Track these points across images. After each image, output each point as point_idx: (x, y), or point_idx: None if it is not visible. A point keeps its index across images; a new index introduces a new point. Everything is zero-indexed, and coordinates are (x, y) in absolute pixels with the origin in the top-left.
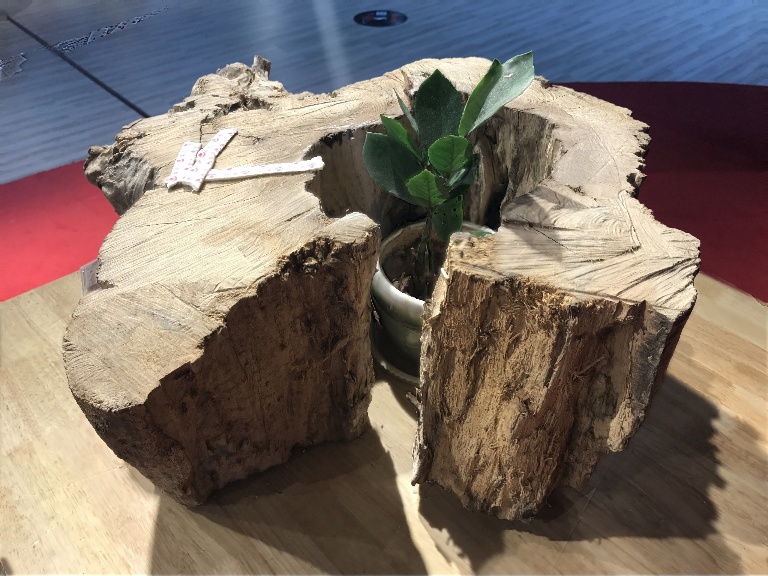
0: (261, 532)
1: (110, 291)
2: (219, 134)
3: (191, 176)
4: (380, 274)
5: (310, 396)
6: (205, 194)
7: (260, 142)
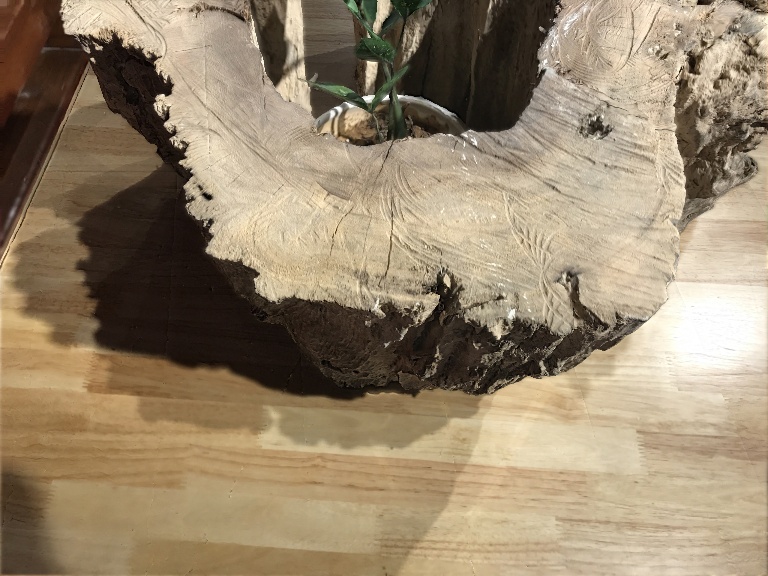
0: None
1: None
2: None
3: None
4: (425, 100)
5: None
6: None
7: None
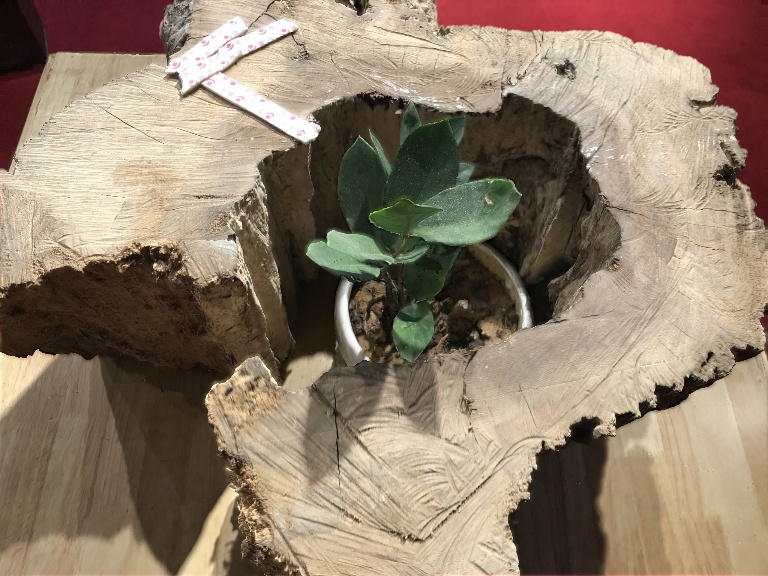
0: (121, 412)
1: (4, 176)
2: (273, 25)
3: (191, 72)
4: None
5: (205, 343)
6: (186, 103)
7: (300, 60)
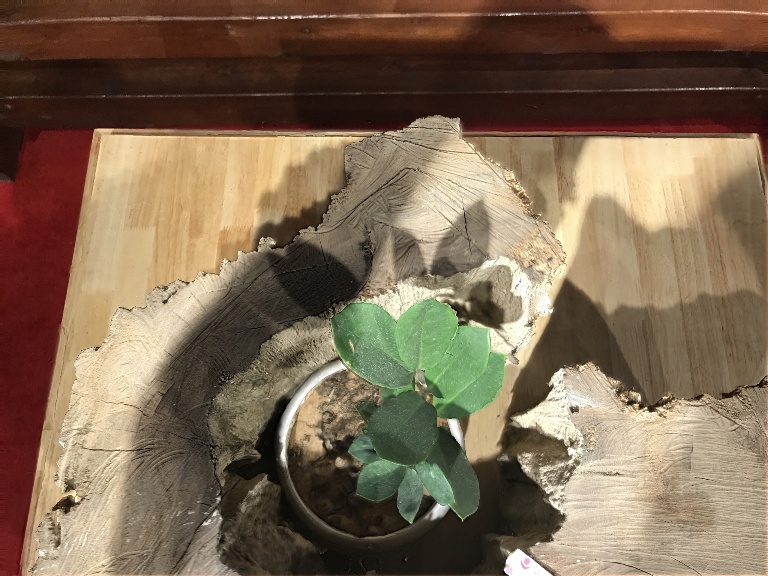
0: None
1: None
2: None
3: None
4: None
5: None
6: None
7: None
